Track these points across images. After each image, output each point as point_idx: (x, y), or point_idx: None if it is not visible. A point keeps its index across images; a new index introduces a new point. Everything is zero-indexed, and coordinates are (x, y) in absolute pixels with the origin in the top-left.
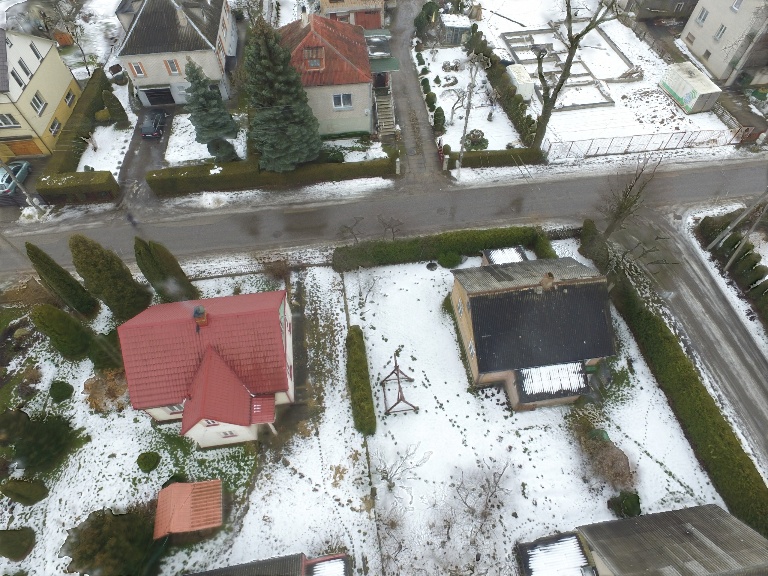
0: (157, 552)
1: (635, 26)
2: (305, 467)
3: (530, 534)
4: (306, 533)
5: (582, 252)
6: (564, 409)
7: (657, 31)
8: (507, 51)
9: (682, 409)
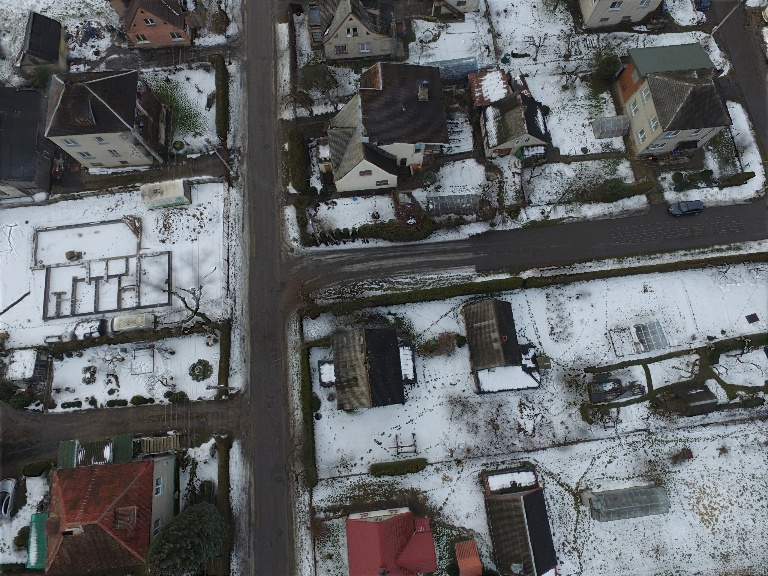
0: (484, 573)
1: (63, 199)
2: (443, 498)
3: (471, 386)
4: (473, 495)
5: (315, 318)
6: (415, 355)
7: (70, 181)
8: (73, 319)
9: (419, 300)
